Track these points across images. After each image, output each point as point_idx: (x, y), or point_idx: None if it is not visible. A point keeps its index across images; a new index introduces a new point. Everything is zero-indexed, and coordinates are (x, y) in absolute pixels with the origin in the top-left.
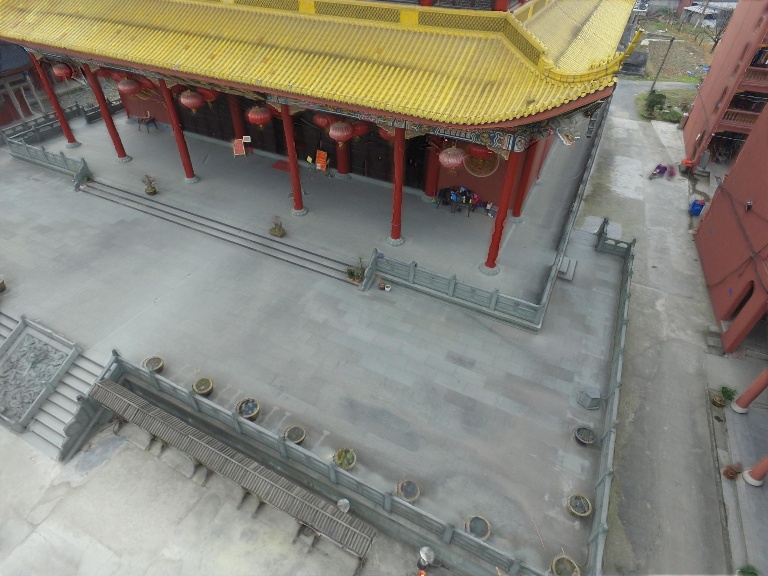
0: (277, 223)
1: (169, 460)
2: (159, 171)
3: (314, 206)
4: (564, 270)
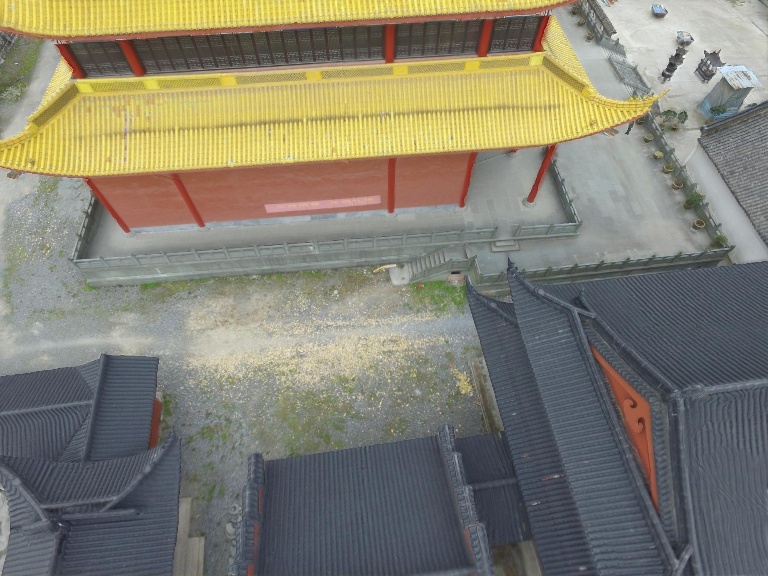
0: None
1: None
2: None
3: None
4: None
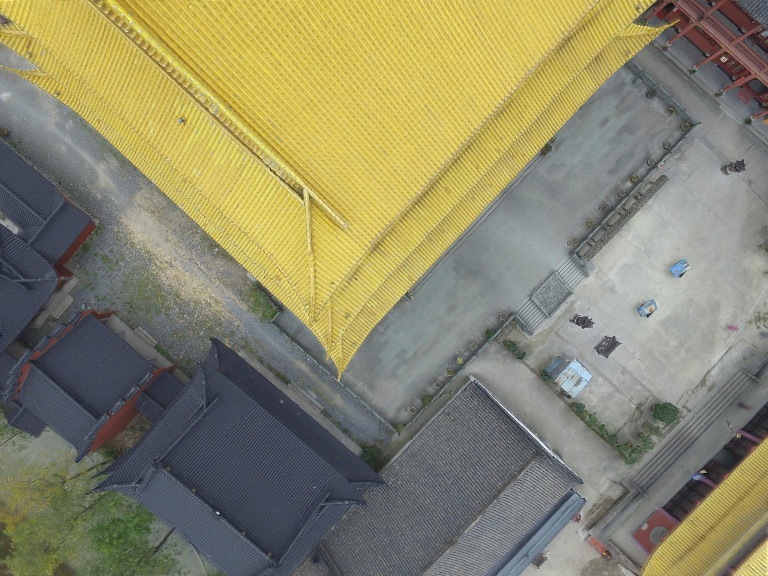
0: None
1: None
2: None
3: None
4: None
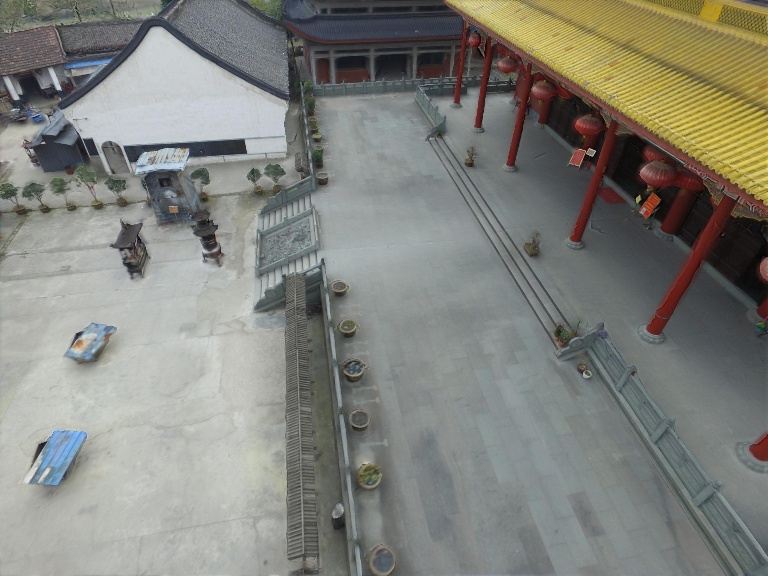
0: (535, 240)
1: None
2: (493, 150)
3: (595, 246)
4: None
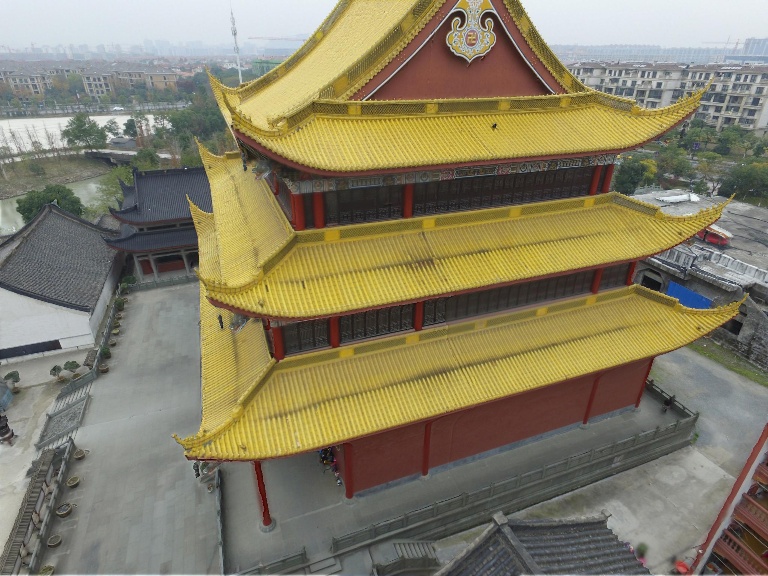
0: None
1: (42, 509)
2: None
3: None
4: (313, 569)
